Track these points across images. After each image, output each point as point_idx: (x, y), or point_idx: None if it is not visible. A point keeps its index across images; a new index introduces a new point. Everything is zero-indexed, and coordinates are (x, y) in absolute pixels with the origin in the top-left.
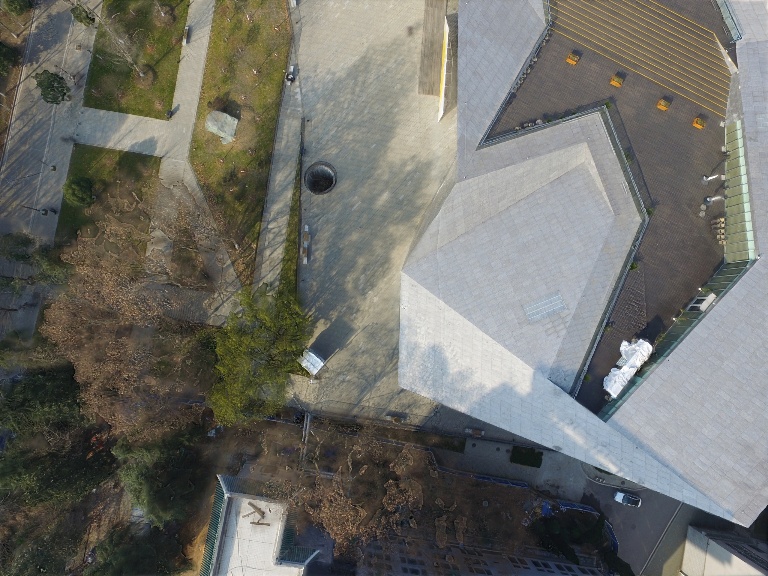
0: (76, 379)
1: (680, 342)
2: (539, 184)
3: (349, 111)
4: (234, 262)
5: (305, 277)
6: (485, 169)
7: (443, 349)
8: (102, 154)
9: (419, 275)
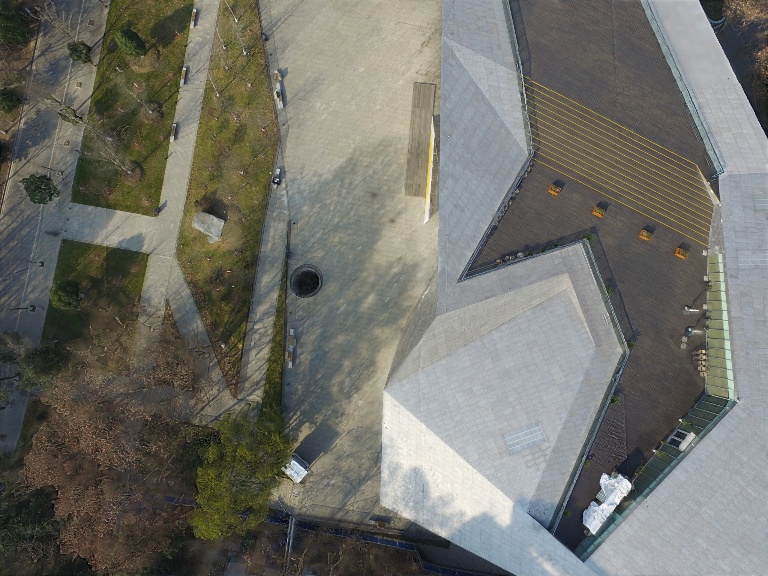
0: (56, 519)
1: (659, 483)
2: (521, 310)
3: (335, 213)
4: (220, 361)
5: (290, 381)
6: (466, 302)
7: (424, 472)
8: (90, 250)
9: (401, 396)
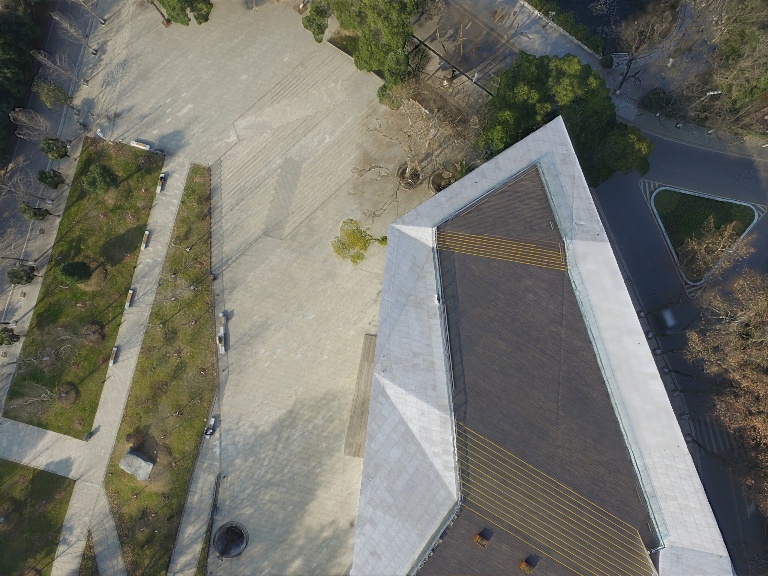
0: None
1: None
2: None
3: (269, 469)
4: None
5: None
6: None
7: None
8: (16, 470)
9: None
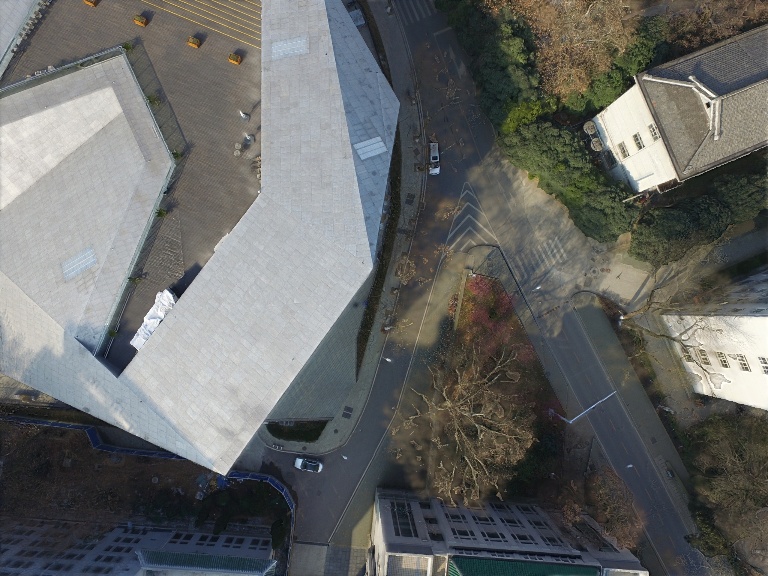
0: None
1: None
2: (83, 136)
3: None
4: None
5: None
6: None
7: (0, 317)
8: None
9: None
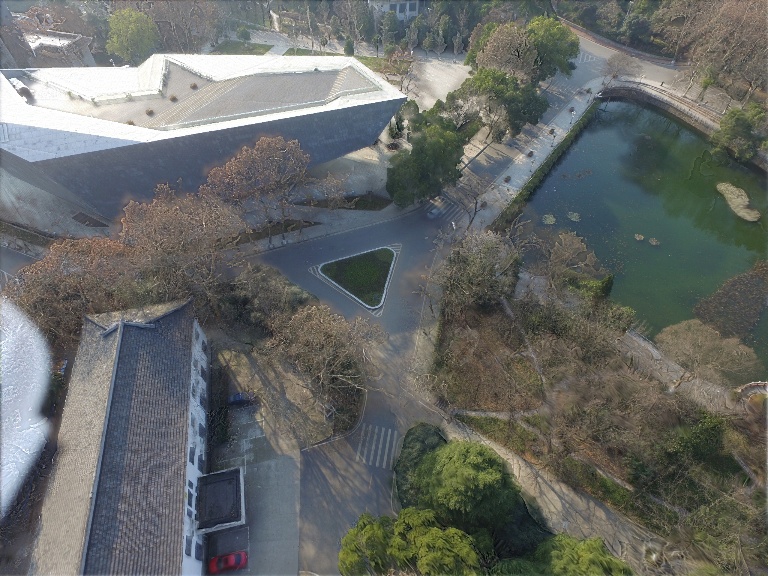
0: None
1: None
2: None
3: None
4: None
5: None
6: (155, 61)
7: None
8: (266, 50)
9: None
